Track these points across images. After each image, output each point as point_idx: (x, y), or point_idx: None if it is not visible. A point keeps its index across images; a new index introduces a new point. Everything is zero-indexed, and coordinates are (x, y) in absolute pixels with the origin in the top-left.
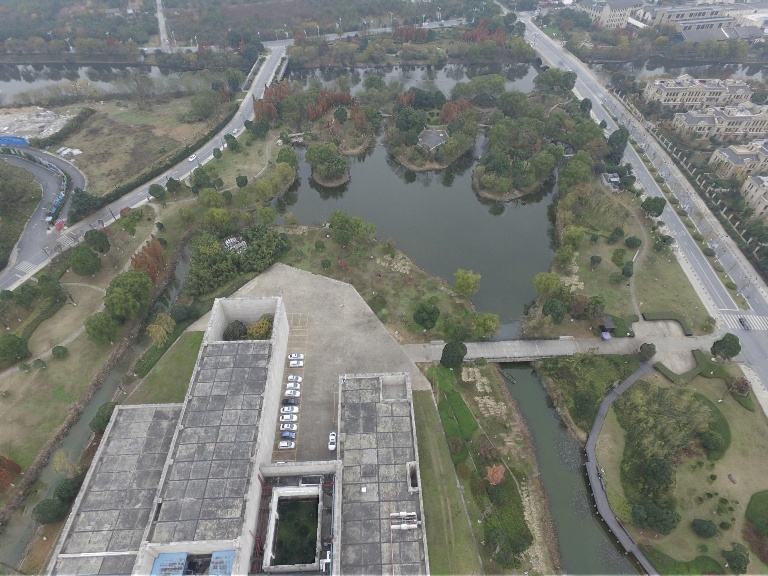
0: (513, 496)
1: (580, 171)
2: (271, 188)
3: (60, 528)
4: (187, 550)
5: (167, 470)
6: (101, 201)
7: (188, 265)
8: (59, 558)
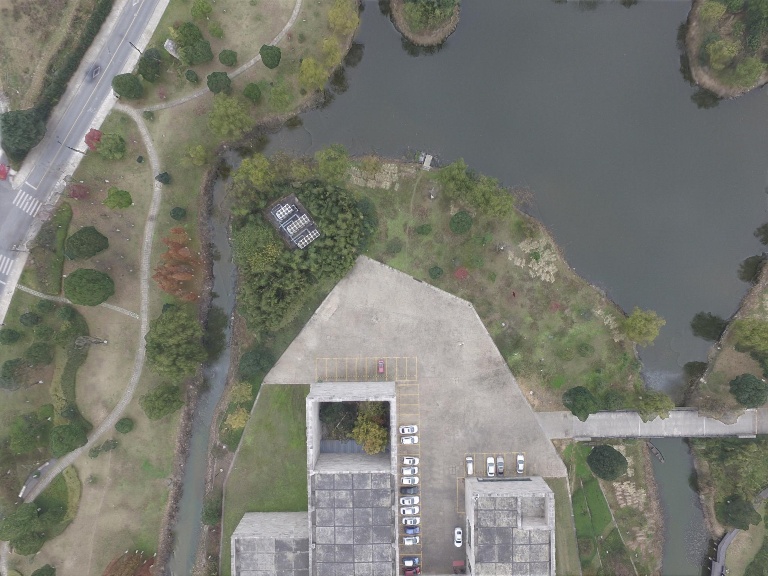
0: None
1: None
2: (326, 74)
3: None
4: None
5: None
6: (41, 113)
7: None
8: None
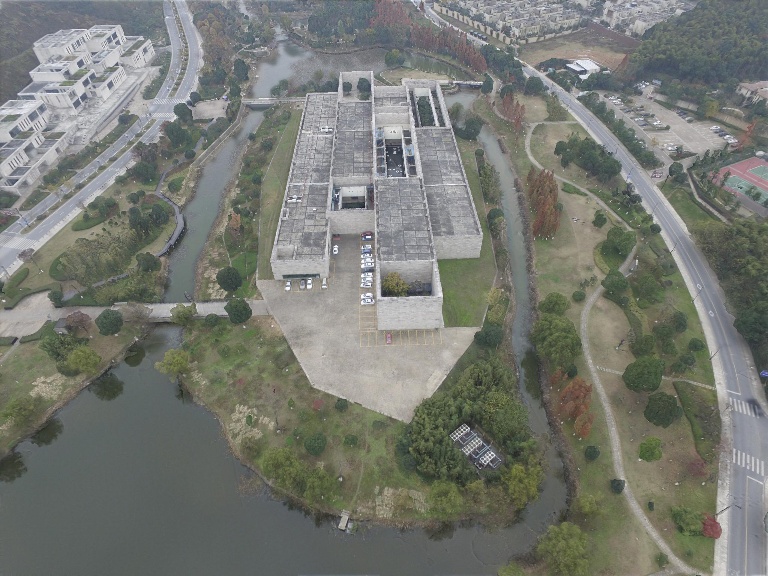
0: None
1: None
2: None
3: None
4: None
5: None
6: None
7: (554, 471)
8: None
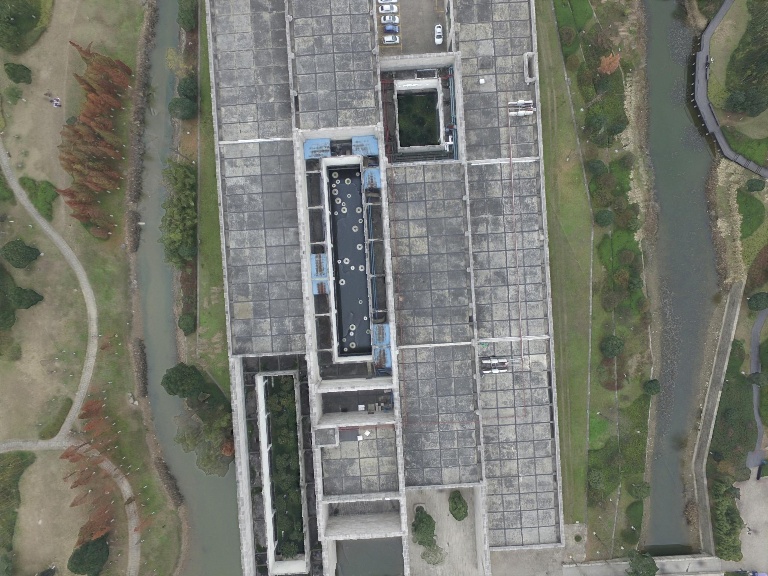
0: (617, 87)
1: None
2: None
3: (197, 124)
4: (330, 136)
5: (291, 64)
6: None
7: None
8: (220, 144)
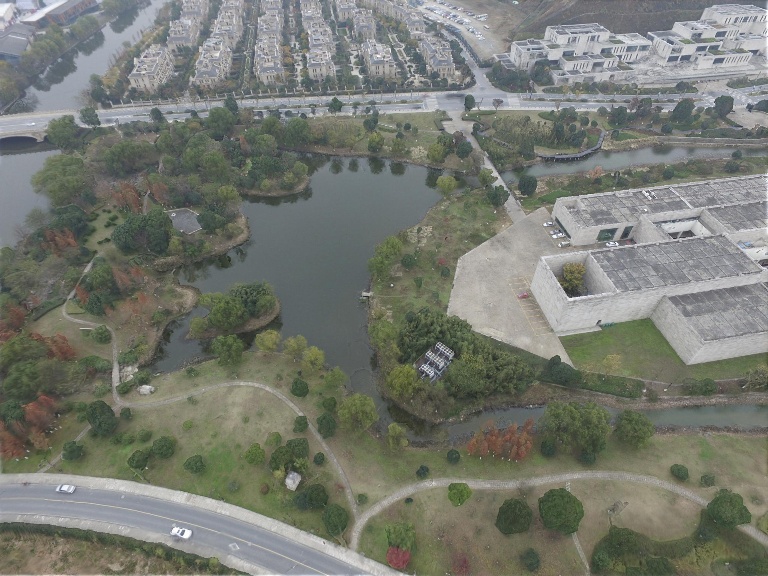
0: None
1: (304, 120)
2: None
3: None
4: None
5: None
6: None
7: None
8: None
